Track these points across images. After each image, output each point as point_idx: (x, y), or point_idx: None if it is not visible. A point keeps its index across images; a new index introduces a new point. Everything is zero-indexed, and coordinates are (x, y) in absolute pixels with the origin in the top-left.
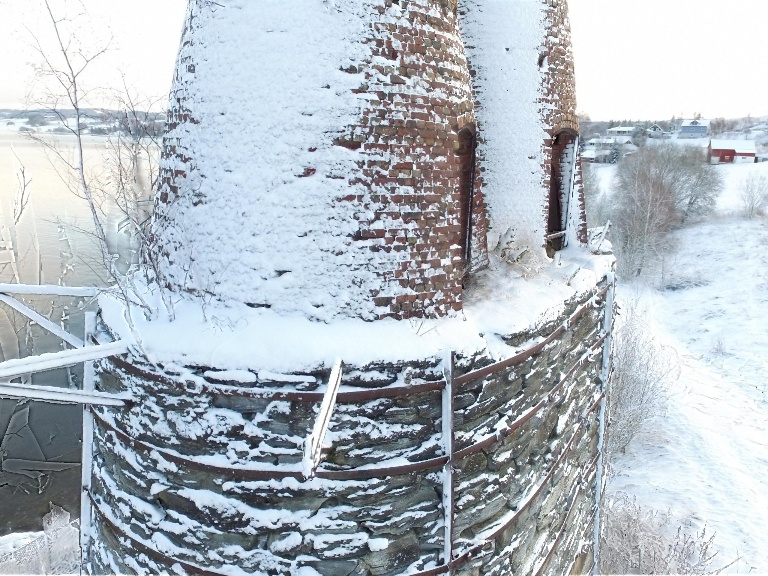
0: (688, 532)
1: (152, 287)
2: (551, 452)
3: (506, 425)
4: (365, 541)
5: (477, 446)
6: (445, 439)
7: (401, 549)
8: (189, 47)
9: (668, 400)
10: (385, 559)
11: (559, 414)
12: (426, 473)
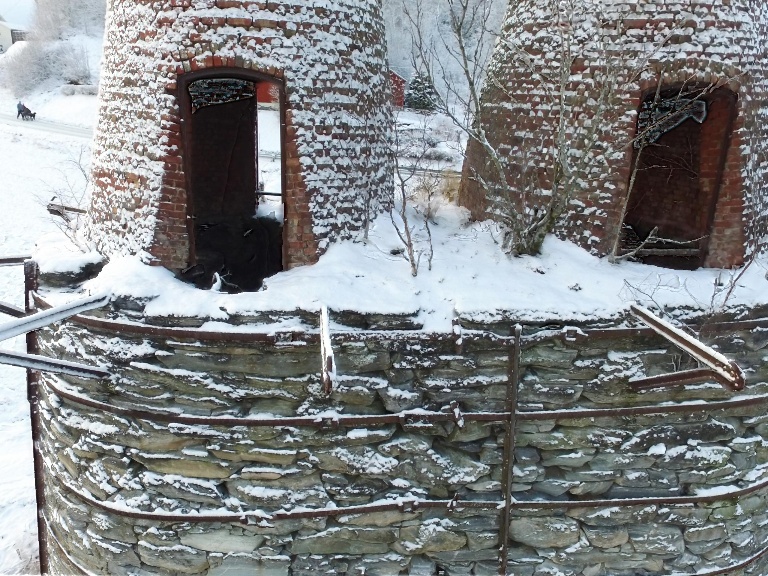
0: (2, 549)
1: None
2: None
3: None
4: None
5: None
6: None
7: None
8: None
9: None
10: None
11: None
12: None
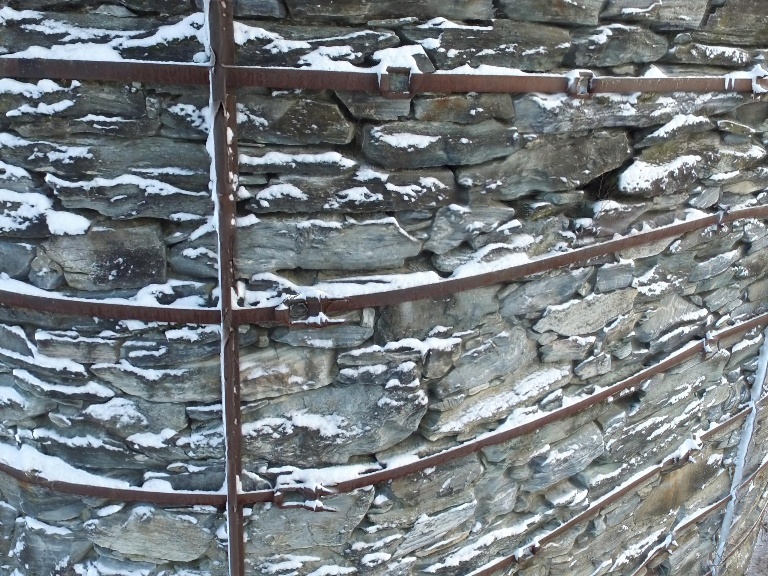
0: None
1: None
2: (593, 217)
3: (411, 63)
4: (40, 210)
5: (310, 76)
6: (206, 22)
7: (123, 250)
8: None
9: None
10: (89, 261)
11: (637, 157)
12: (174, 102)
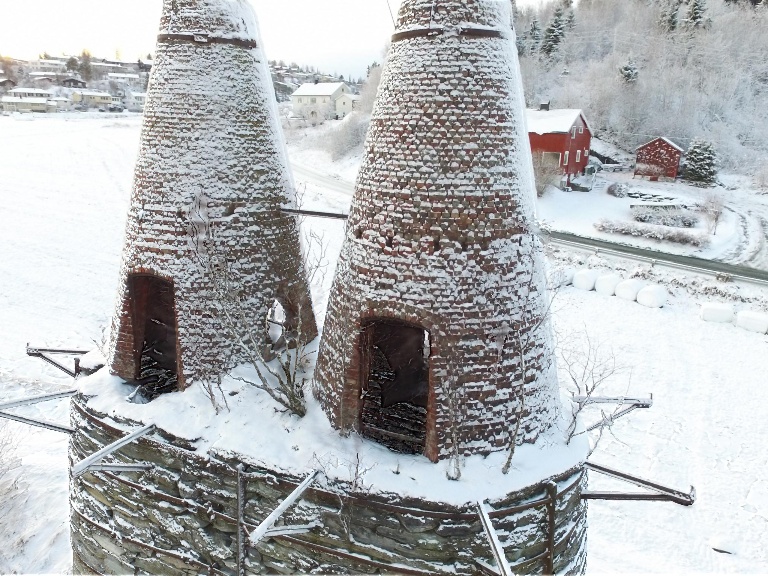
0: None
1: (545, 437)
2: None
3: None
4: None
5: None
6: None
7: None
8: (527, 276)
9: (16, 449)
10: None
11: None
12: None
